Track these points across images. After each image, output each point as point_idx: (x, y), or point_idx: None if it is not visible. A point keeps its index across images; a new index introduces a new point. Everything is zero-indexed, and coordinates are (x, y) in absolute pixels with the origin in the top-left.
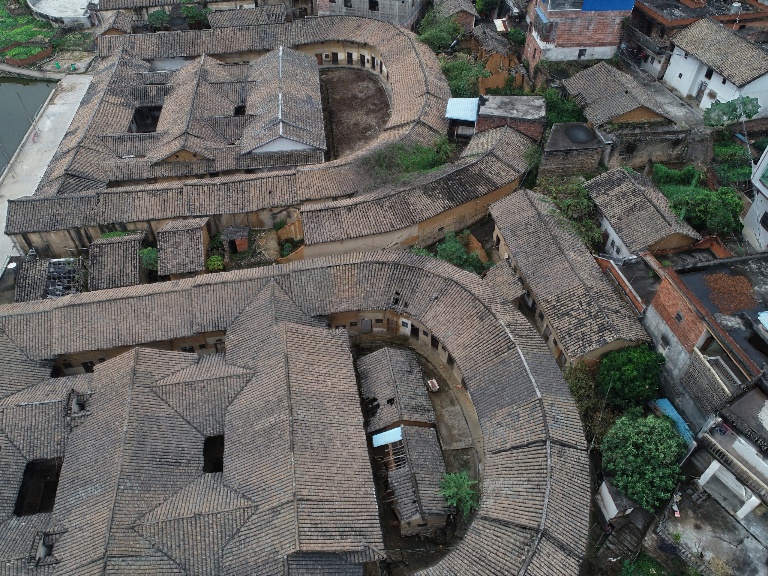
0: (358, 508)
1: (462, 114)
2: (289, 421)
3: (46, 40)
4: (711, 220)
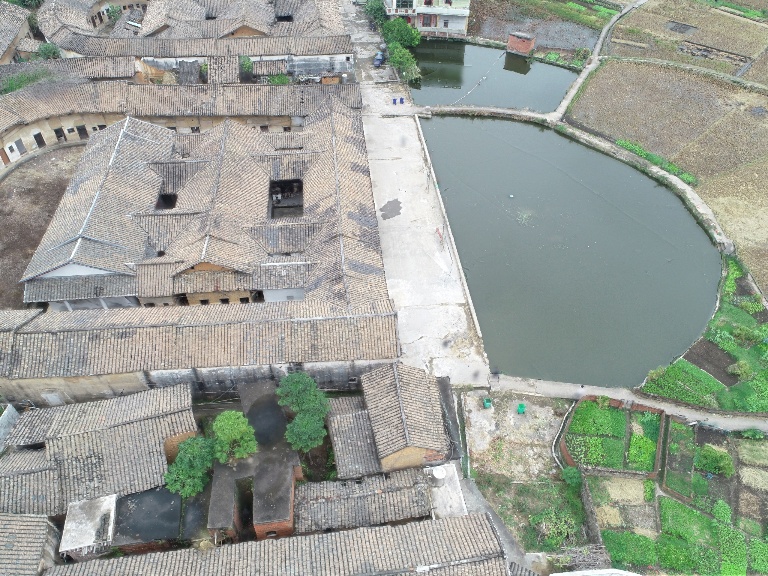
0: (155, 1)
1: None
2: (172, 2)
3: (616, 512)
4: None
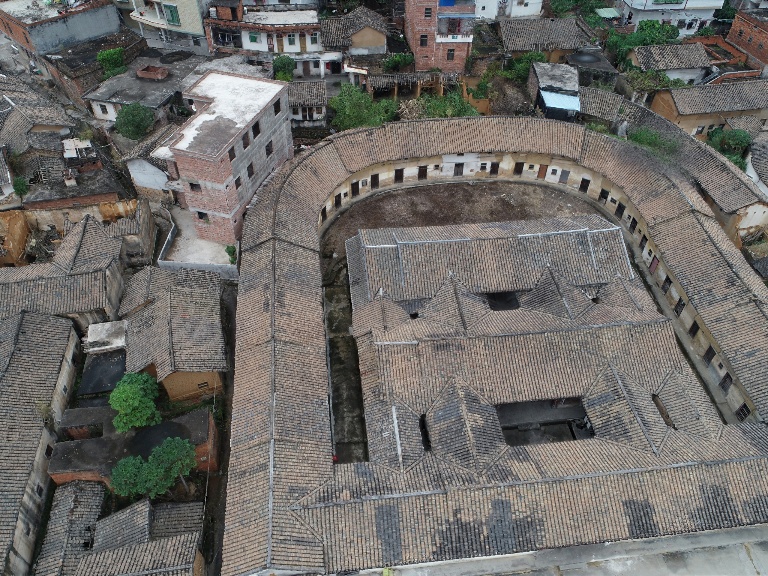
0: None
1: (572, 102)
2: None
3: None
4: (673, 34)
